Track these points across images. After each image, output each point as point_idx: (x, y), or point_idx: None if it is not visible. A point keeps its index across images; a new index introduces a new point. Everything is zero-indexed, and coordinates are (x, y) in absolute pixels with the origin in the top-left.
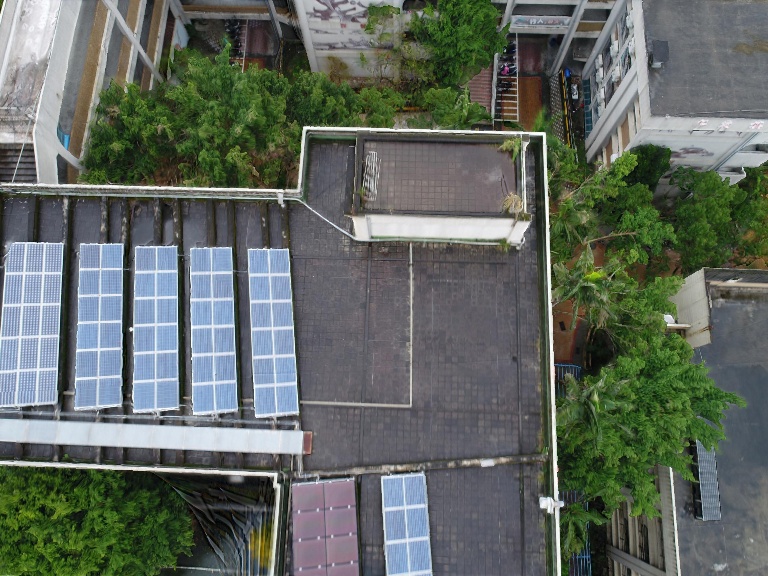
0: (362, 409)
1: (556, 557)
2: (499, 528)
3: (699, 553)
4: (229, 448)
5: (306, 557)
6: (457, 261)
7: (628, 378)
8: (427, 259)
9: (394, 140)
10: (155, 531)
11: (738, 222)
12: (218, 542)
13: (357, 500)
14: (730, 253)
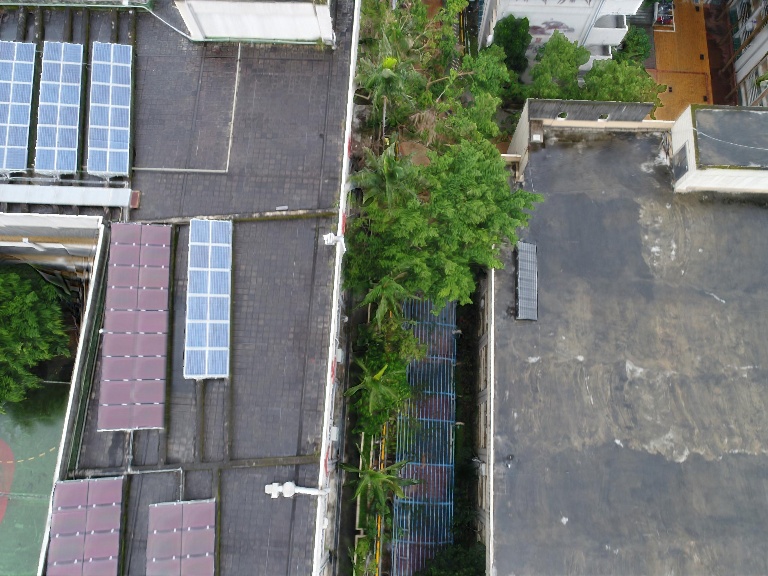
0: (185, 174)
1: (334, 281)
2: (294, 267)
3: (516, 348)
4: (66, 202)
5: (120, 279)
6: (279, 58)
7: (438, 173)
8: (253, 56)
9: None
10: (26, 314)
11: None
12: (72, 310)
13: (173, 243)
14: None
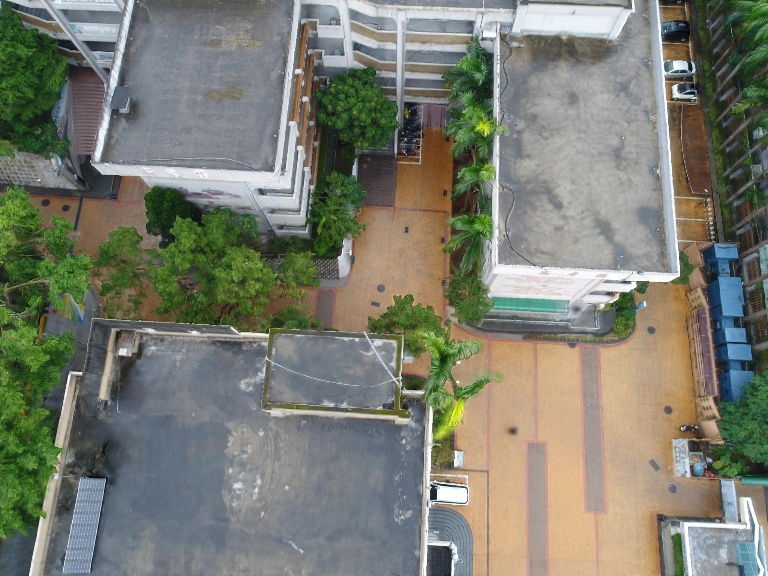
0: None
1: None
2: None
3: None
4: None
5: None
6: None
7: None
8: None
9: None
10: None
11: None
12: None
13: None
14: (202, 299)
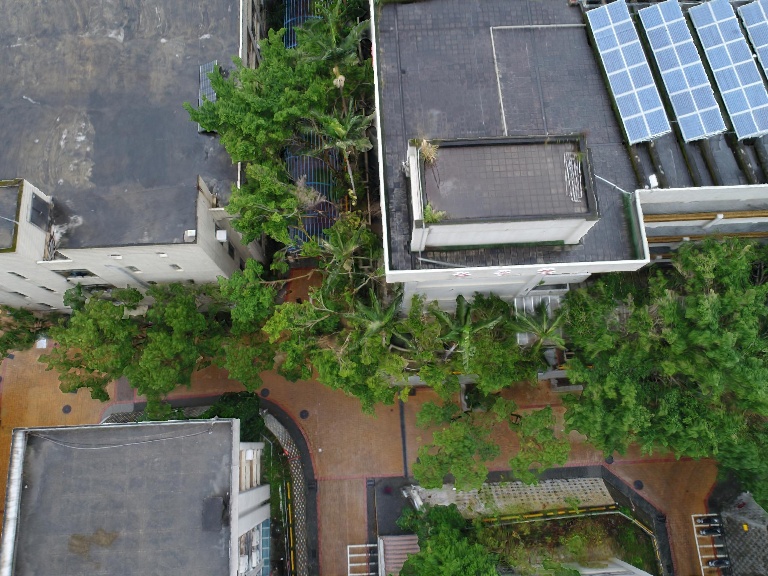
0: None
1: None
2: None
3: (221, 44)
4: None
5: None
6: None
7: (289, 107)
8: None
9: (557, 215)
10: None
11: (132, 356)
12: None
13: None
14: (150, 312)
